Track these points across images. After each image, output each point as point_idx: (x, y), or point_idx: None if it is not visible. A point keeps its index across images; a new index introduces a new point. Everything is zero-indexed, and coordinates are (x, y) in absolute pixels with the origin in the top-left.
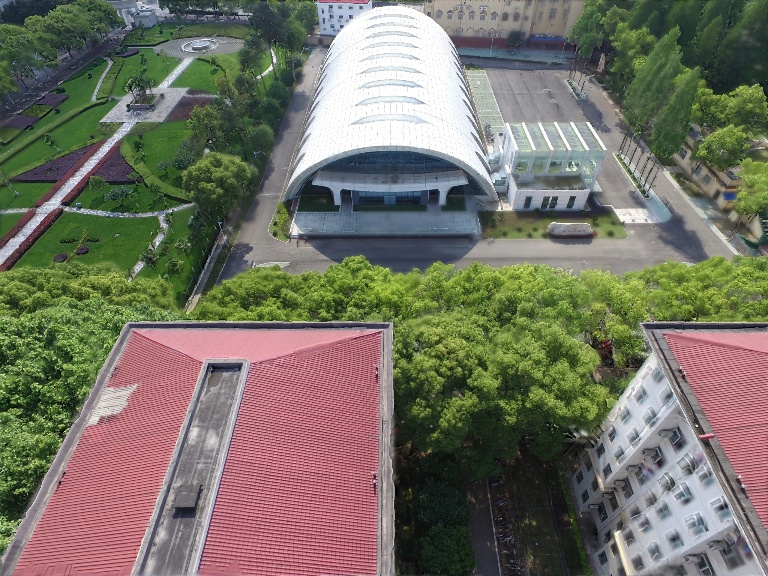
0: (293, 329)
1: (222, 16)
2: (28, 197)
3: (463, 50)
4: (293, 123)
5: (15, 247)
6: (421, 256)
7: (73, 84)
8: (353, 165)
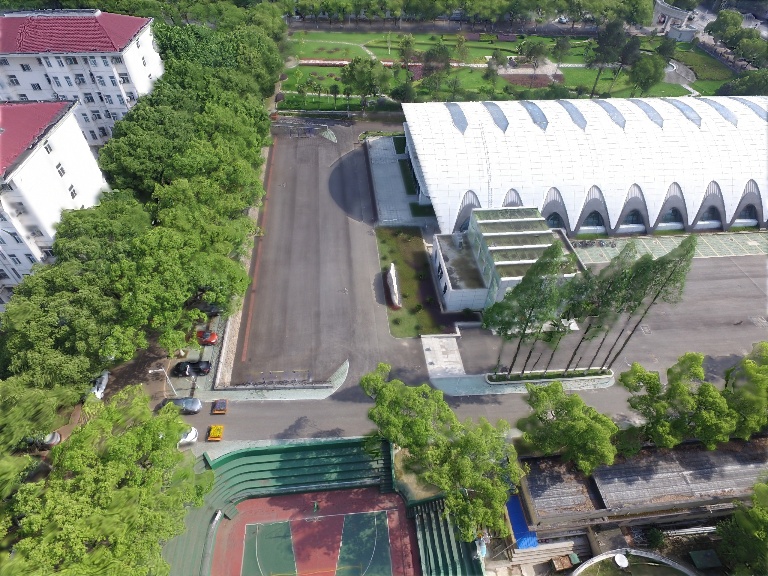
0: None
1: None
2: (387, 57)
3: None
4: None
5: None
6: (348, 195)
7: (537, 39)
8: None
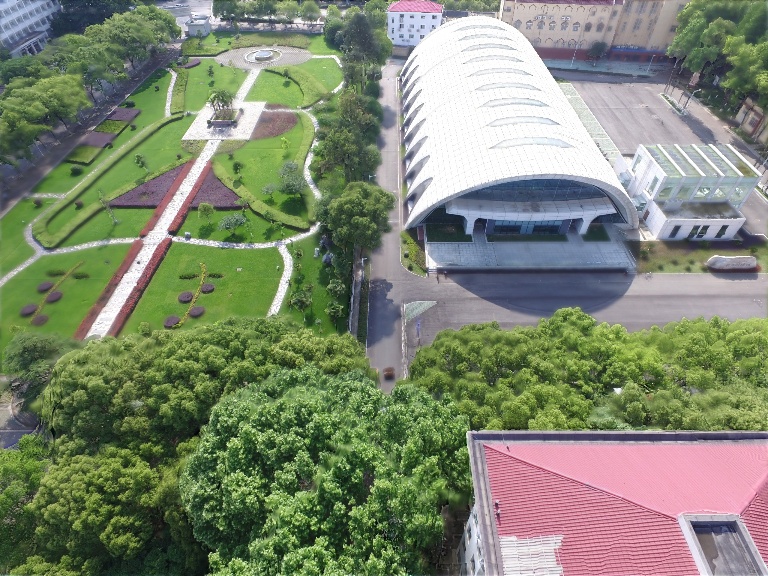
0: (681, 441)
1: (278, 24)
2: (129, 225)
3: None
4: (387, 141)
5: (132, 284)
6: (578, 293)
7: (141, 97)
8: (485, 191)
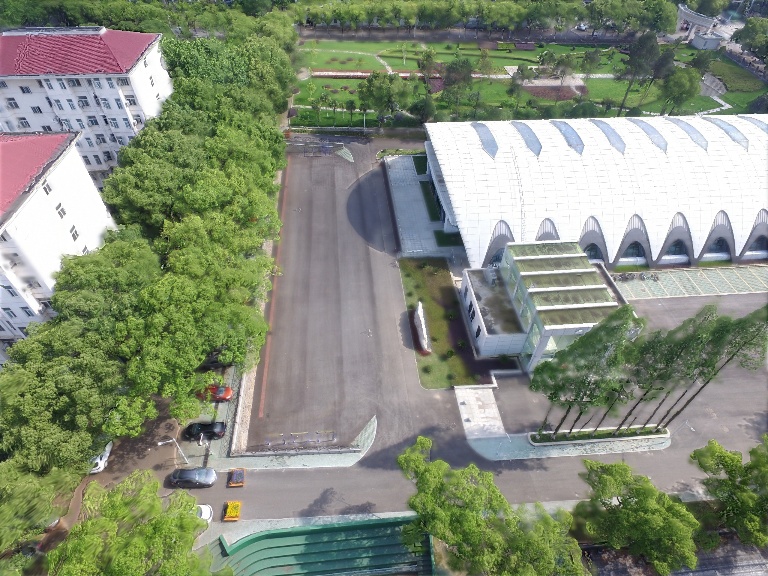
0: None
1: None
2: (403, 68)
3: None
4: None
5: None
6: (368, 222)
7: (556, 47)
8: None
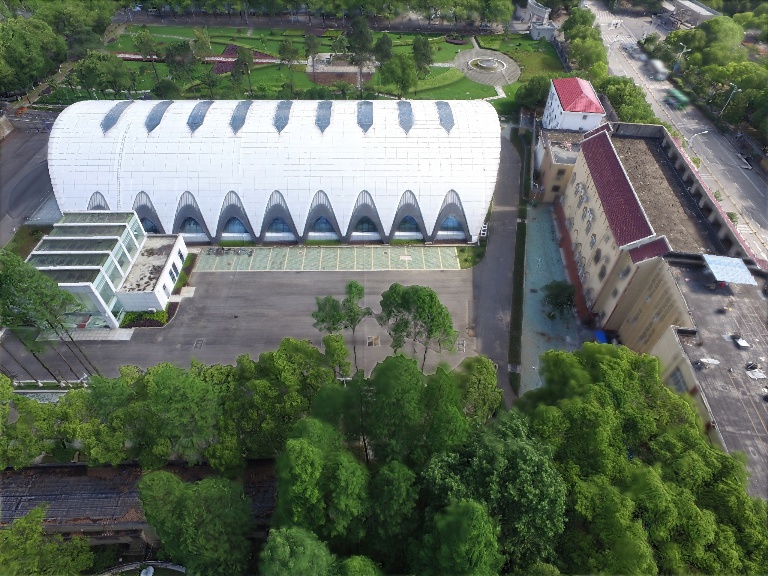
0: None
1: None
2: None
3: (550, 250)
4: None
5: None
6: (28, 192)
7: None
8: None
